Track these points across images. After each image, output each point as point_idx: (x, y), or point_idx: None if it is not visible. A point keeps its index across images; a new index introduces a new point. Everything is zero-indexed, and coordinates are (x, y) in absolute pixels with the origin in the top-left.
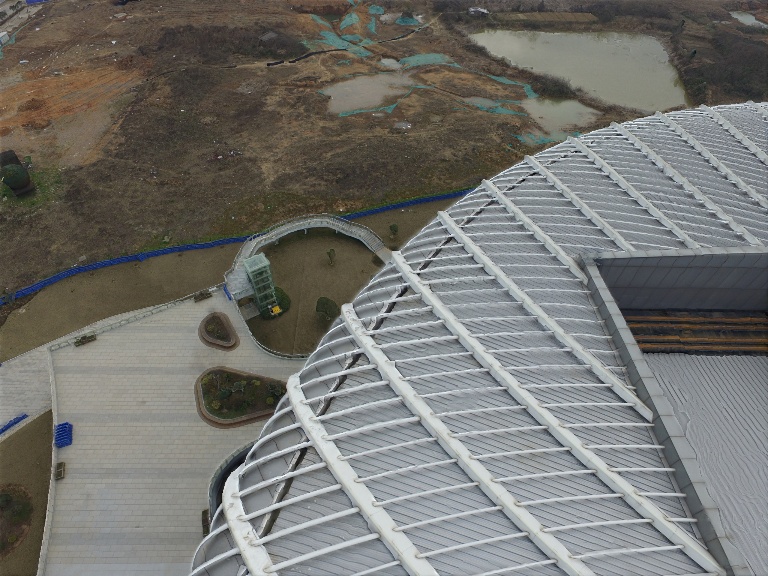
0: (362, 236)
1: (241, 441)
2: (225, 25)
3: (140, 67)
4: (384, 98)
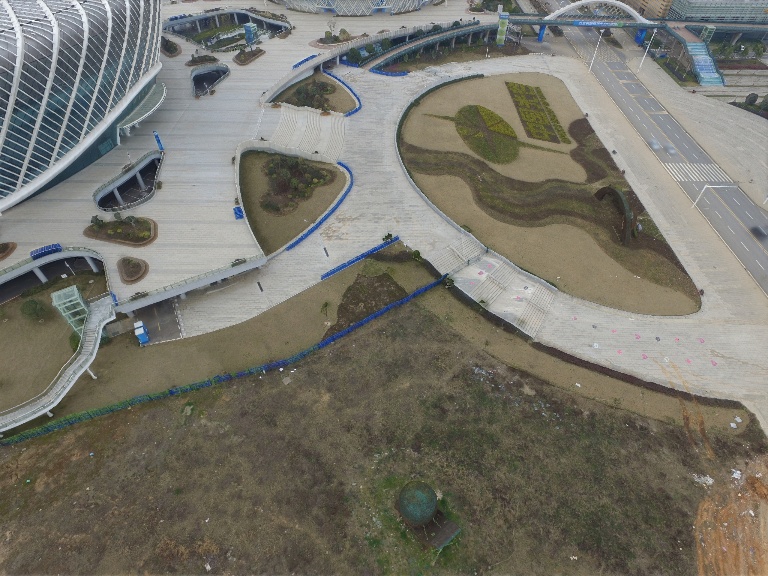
0: None
1: (133, 212)
2: None
3: None
4: None
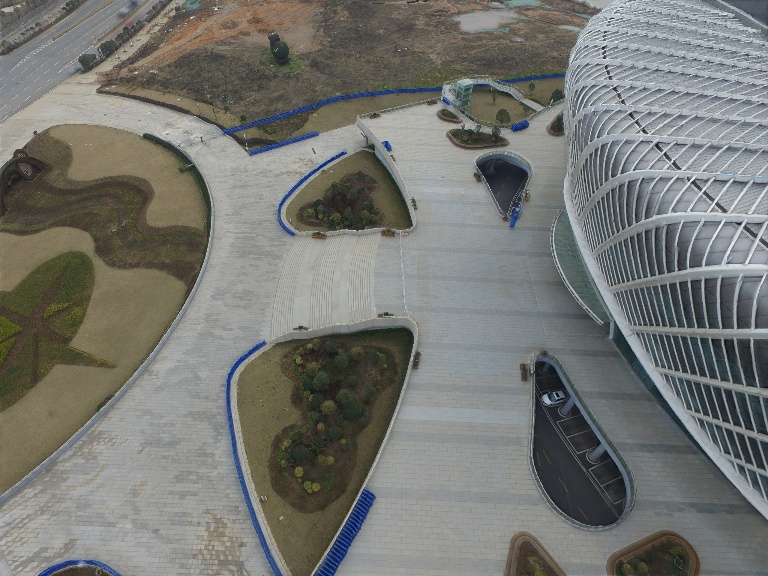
0: (511, 90)
1: None
2: None
3: (317, 1)
4: (499, 24)
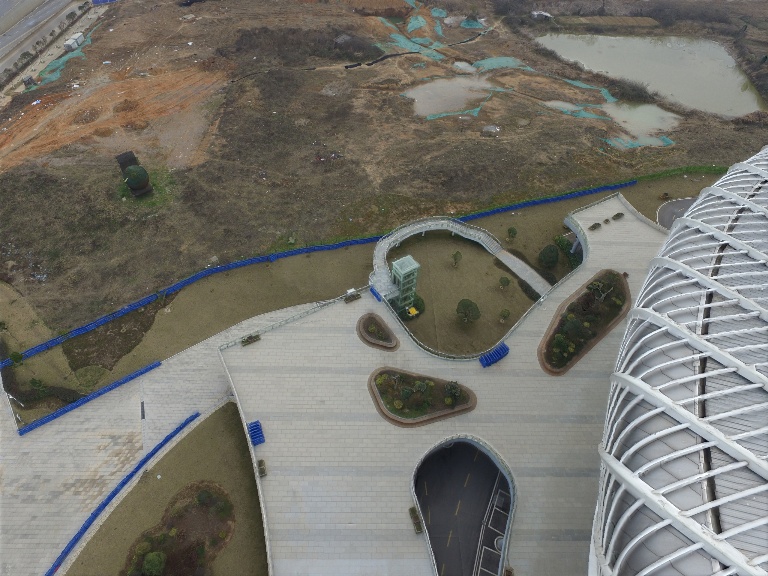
0: (481, 239)
1: (427, 440)
2: (299, 27)
3: (223, 69)
4: (467, 101)
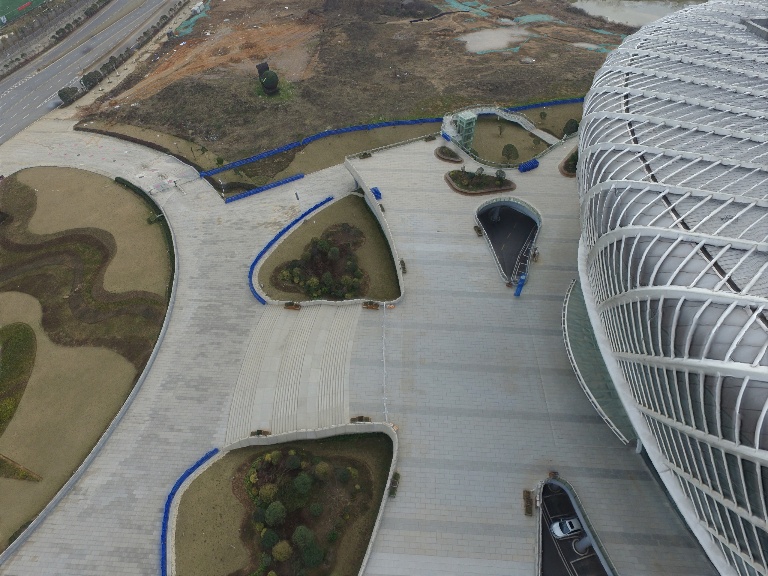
0: (520, 120)
1: None
2: None
3: (315, 23)
4: (509, 43)
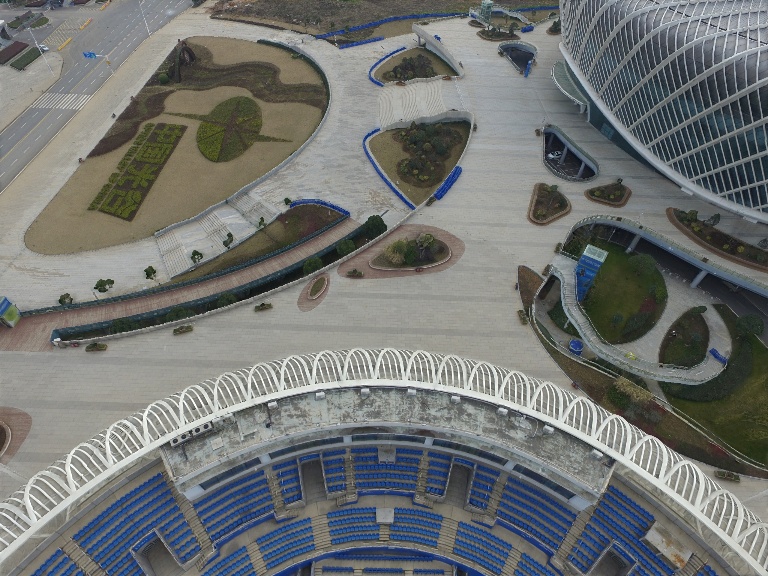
0: (518, 15)
1: None
2: None
3: None
4: None
